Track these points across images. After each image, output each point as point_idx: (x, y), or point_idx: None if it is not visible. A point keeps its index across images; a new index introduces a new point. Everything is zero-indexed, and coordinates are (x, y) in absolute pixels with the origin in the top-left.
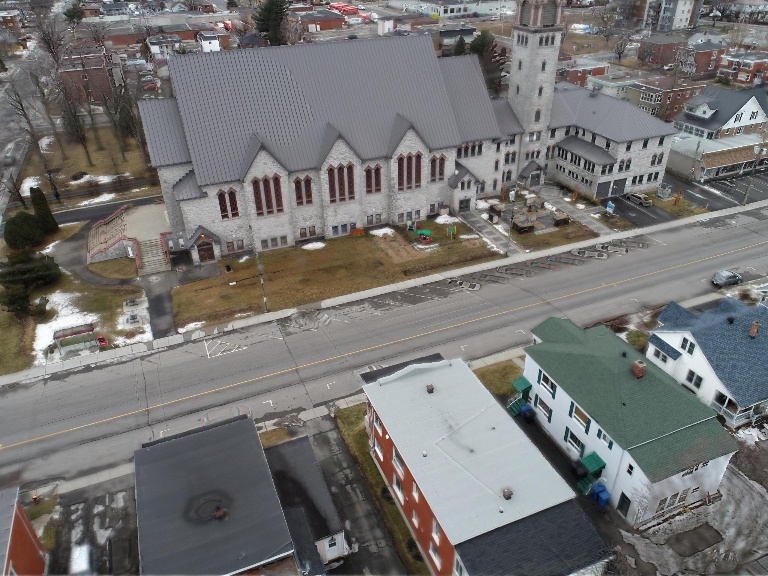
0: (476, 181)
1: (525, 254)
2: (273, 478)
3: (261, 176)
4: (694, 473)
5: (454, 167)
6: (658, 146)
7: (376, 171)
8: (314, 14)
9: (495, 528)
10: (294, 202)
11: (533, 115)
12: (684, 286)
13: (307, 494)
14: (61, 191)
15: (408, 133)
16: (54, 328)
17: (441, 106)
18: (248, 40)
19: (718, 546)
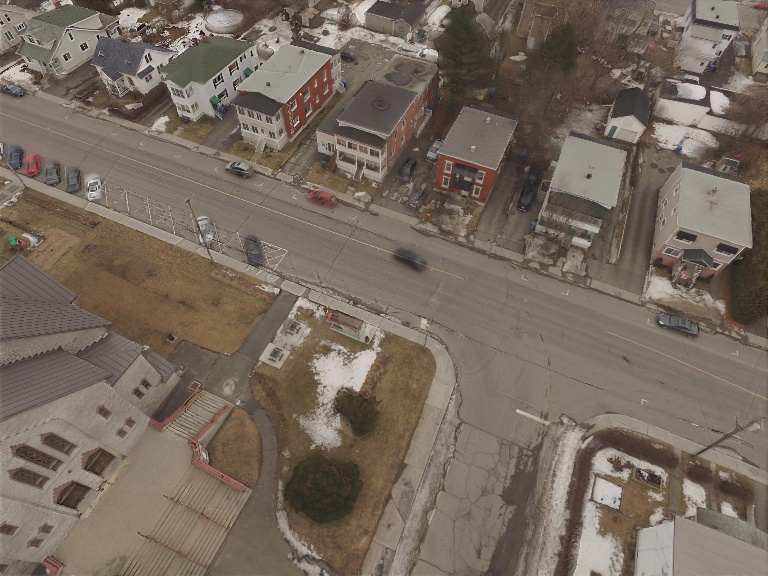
0: None
1: (15, 181)
2: None
3: None
4: None
5: None
6: None
7: None
8: None
9: None
10: None
11: None
12: (32, 106)
13: None
14: None
15: None
16: (350, 373)
17: None
18: None
19: None
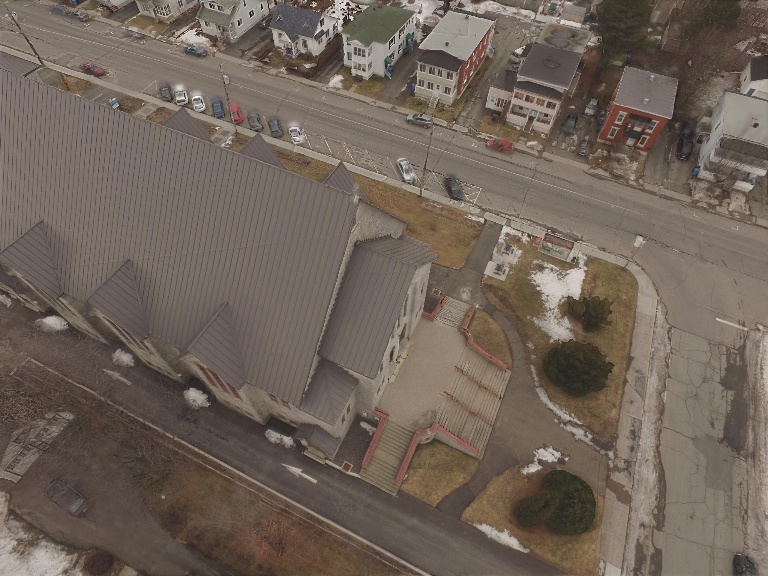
0: None
1: (225, 127)
2: None
3: None
4: None
5: None
6: None
7: None
8: None
9: None
10: None
11: None
12: (216, 65)
13: None
14: None
15: None
16: (566, 286)
17: None
18: None
19: None
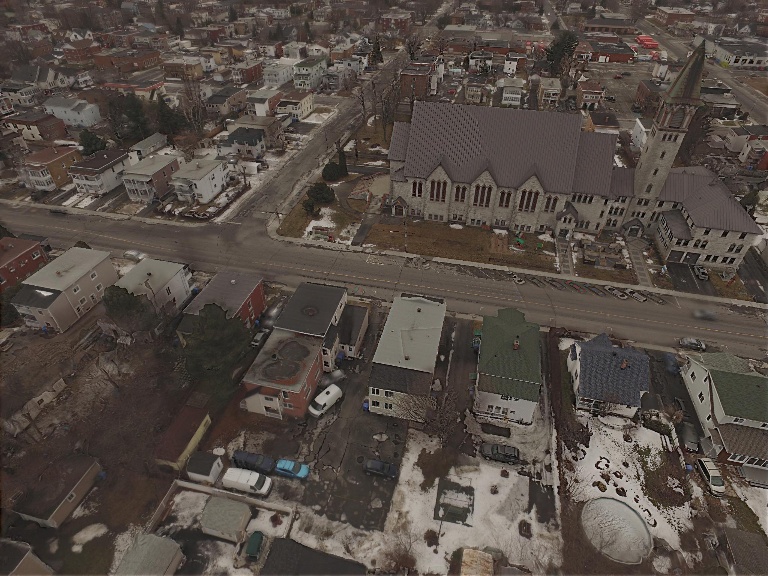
0: (575, 220)
1: (572, 276)
2: (344, 316)
3: (437, 179)
4: (509, 401)
5: (563, 206)
6: (738, 239)
7: (508, 195)
8: (612, 46)
9: (392, 365)
10: (453, 198)
11: (645, 187)
12: (656, 336)
13: (352, 328)
14: (362, 153)
15: (533, 178)
16: (317, 224)
17: (568, 165)
18: (539, 65)
19: (503, 438)
